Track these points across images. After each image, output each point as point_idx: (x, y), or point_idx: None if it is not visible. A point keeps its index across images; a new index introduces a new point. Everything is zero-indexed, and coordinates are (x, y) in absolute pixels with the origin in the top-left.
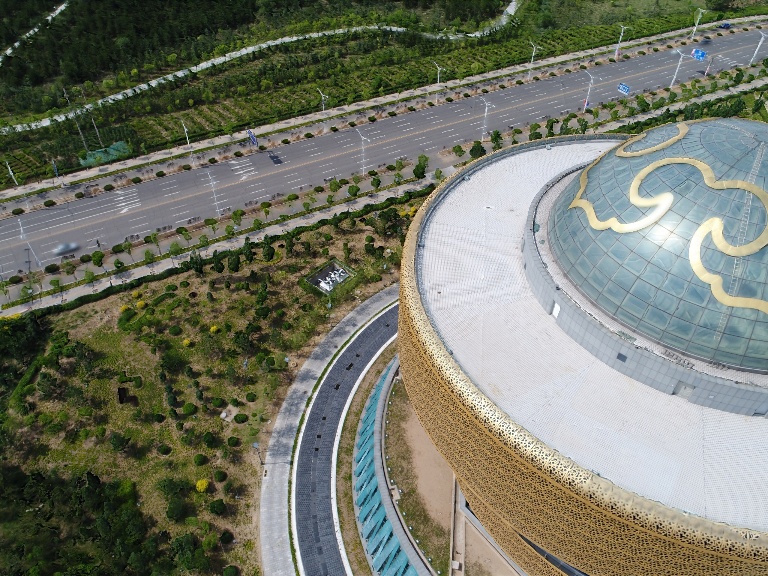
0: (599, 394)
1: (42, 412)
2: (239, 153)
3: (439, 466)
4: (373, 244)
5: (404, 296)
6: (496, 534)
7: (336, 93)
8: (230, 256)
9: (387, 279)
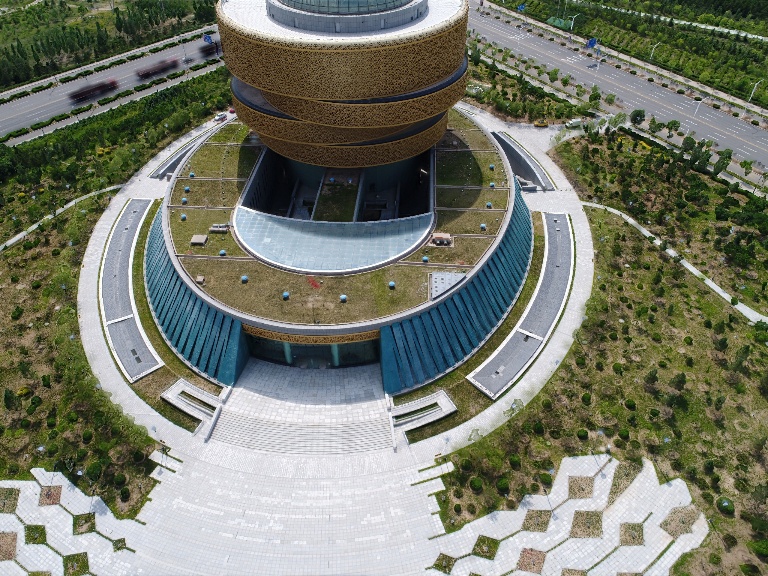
0: None
1: None
2: (590, 54)
3: None
4: (506, 93)
5: None
6: None
7: None
8: None
9: (483, 106)
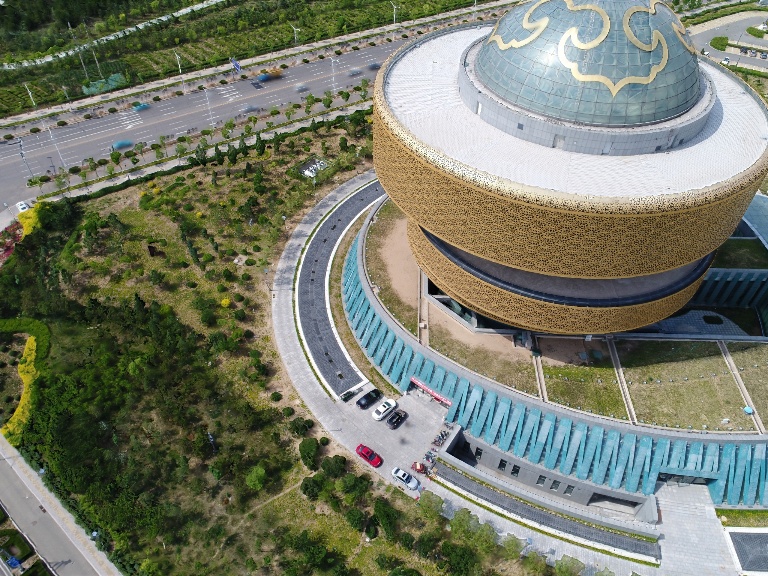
0: (506, 149)
1: None
2: (224, 81)
3: (407, 272)
4: (346, 142)
5: (377, 107)
6: (448, 279)
7: (305, 32)
8: (229, 149)
9: (359, 168)
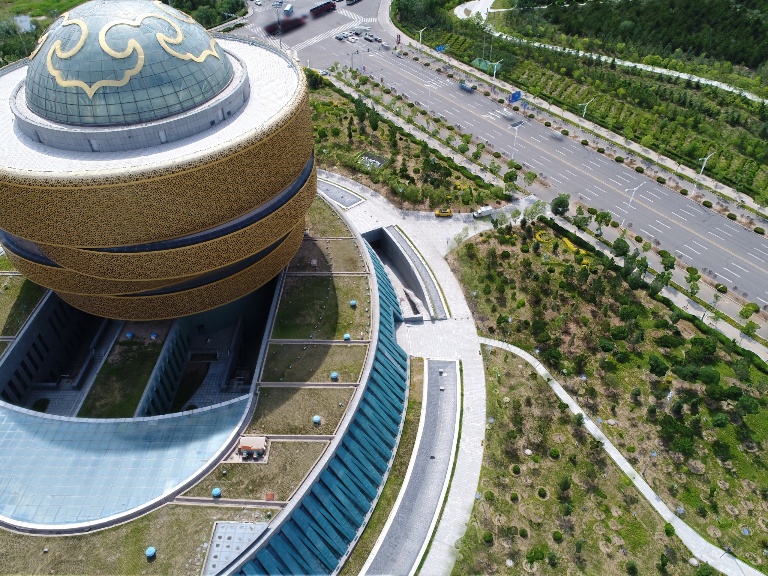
0: None
1: None
2: (516, 108)
3: None
4: (405, 169)
5: None
6: None
7: None
8: None
9: (377, 186)
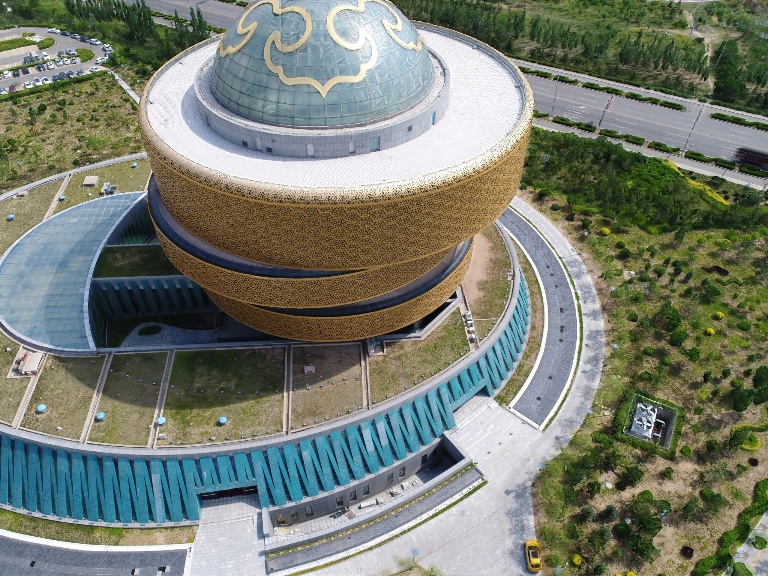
0: None
1: (760, 251)
2: None
3: None
4: (633, 474)
5: None
6: None
7: None
8: None
9: None
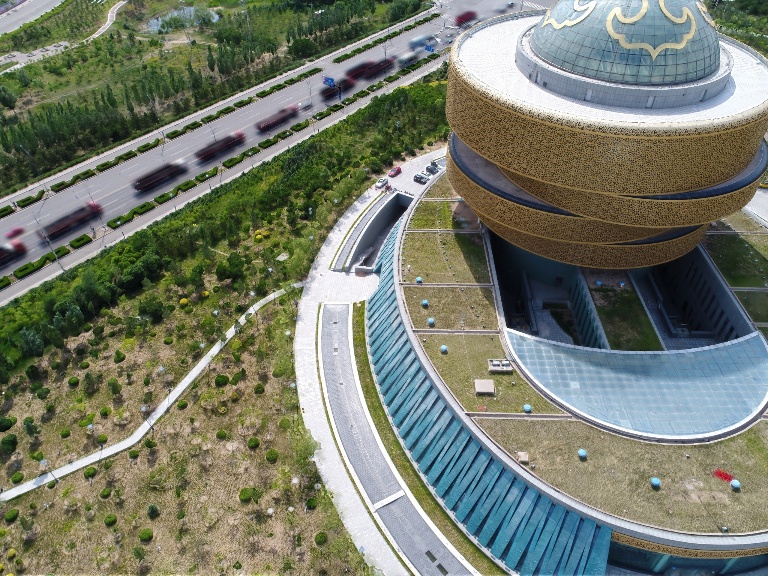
0: None
1: None
2: None
3: None
4: None
5: None
6: None
7: None
8: None
9: None
